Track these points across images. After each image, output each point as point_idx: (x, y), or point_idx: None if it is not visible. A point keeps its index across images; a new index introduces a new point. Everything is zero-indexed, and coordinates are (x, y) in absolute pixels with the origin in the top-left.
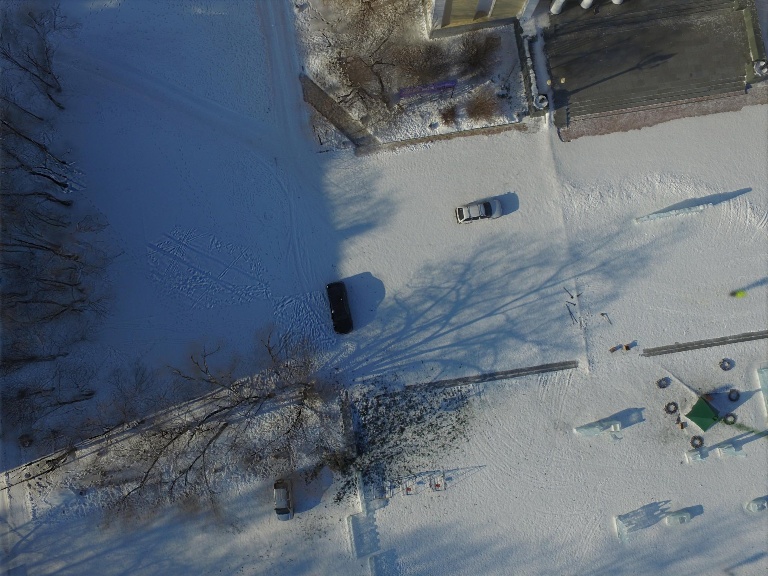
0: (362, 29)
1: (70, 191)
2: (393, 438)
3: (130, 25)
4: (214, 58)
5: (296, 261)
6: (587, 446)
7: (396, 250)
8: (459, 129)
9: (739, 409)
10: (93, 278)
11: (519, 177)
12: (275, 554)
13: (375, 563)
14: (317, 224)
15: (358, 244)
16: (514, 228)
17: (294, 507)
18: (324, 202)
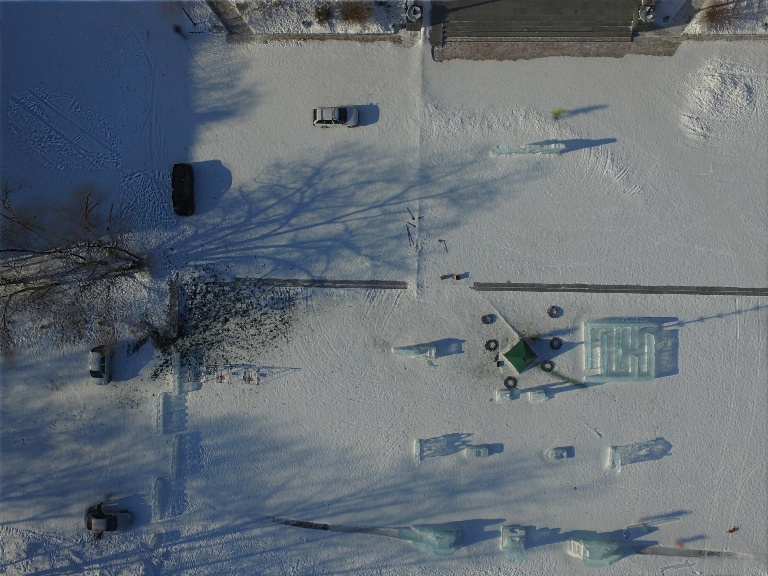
0: None
1: None
2: (216, 326)
3: None
4: None
5: (151, 137)
6: (402, 367)
7: (250, 143)
8: (333, 31)
9: (558, 358)
10: None
11: (384, 90)
12: (88, 416)
13: (179, 441)
14: (177, 104)
15: (214, 131)
16: (369, 140)
17: (112, 375)
18: (187, 83)
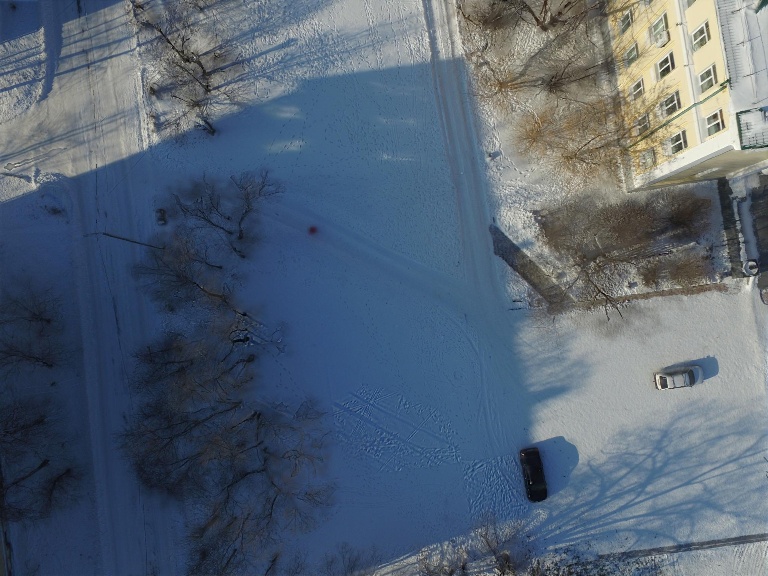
0: (557, 180)
1: (251, 344)
2: None
3: (312, 169)
4: (402, 207)
5: (487, 423)
6: None
7: (590, 414)
8: (658, 289)
9: None
10: (307, 466)
11: (719, 340)
12: None
13: None
14: (509, 385)
15: (551, 407)
16: (713, 394)
17: None
18: (516, 362)
